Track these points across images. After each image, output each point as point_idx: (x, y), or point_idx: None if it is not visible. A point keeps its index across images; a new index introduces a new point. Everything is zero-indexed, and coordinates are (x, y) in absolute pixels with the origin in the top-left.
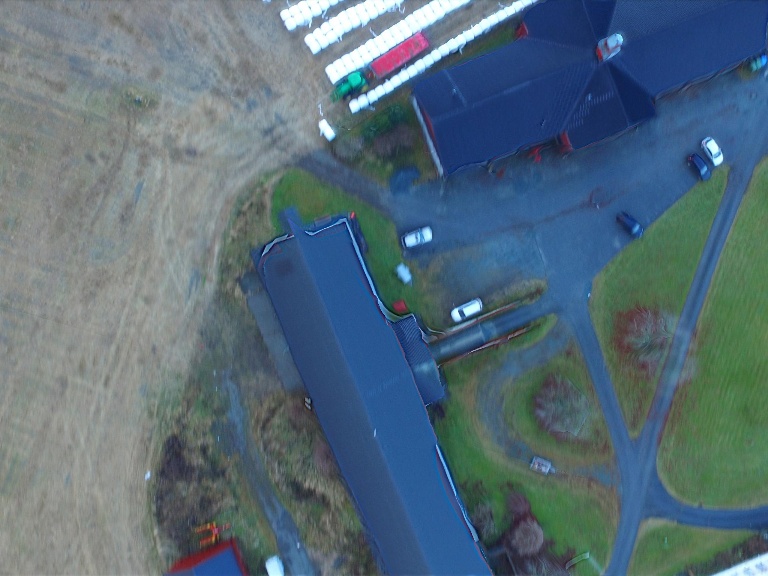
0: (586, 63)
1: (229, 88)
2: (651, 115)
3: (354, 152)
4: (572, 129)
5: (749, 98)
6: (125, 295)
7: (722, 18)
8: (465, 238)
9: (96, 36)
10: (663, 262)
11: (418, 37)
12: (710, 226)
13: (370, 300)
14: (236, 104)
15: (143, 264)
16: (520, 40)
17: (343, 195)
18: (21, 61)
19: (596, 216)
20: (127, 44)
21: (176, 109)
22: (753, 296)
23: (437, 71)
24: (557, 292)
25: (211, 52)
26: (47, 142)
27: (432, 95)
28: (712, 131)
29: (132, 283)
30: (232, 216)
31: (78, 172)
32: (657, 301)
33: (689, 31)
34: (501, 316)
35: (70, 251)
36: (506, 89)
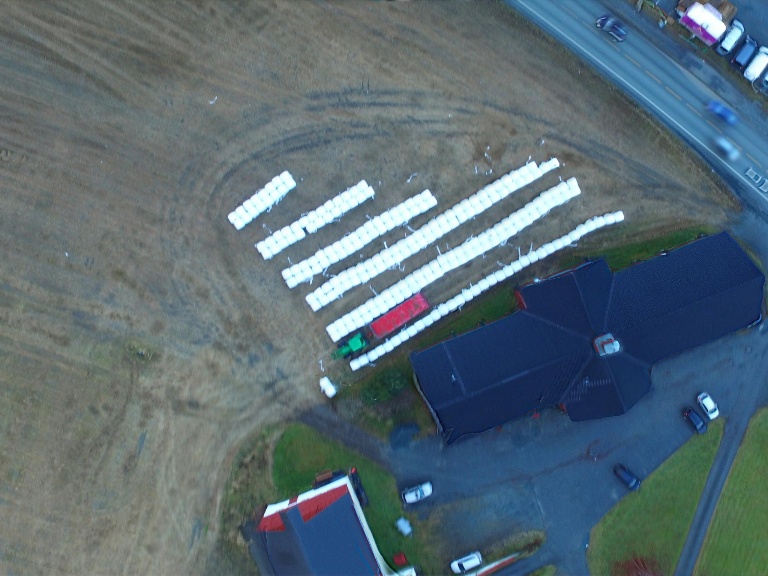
0: (583, 351)
1: (231, 342)
2: (648, 391)
3: (355, 409)
4: (570, 403)
5: (744, 352)
6: (128, 544)
7: (717, 305)
8: (464, 491)
9: (99, 291)
10: (660, 513)
11: (418, 299)
12: (706, 477)
13: (371, 574)
14: (238, 358)
15: (146, 513)
16: (518, 314)
17: (344, 449)
18: (25, 316)
19: (594, 468)
20: (130, 299)
21: (179, 362)
22: (748, 545)
23: (437, 329)
24: (555, 544)
25: (213, 307)
26: (51, 395)
27: (432, 377)
28: (708, 385)
29: (135, 532)
30: (234, 467)
31: (82, 424)
32: (654, 551)
33: (685, 318)
34: (500, 571)
35: (74, 501)
36: (505, 378)
